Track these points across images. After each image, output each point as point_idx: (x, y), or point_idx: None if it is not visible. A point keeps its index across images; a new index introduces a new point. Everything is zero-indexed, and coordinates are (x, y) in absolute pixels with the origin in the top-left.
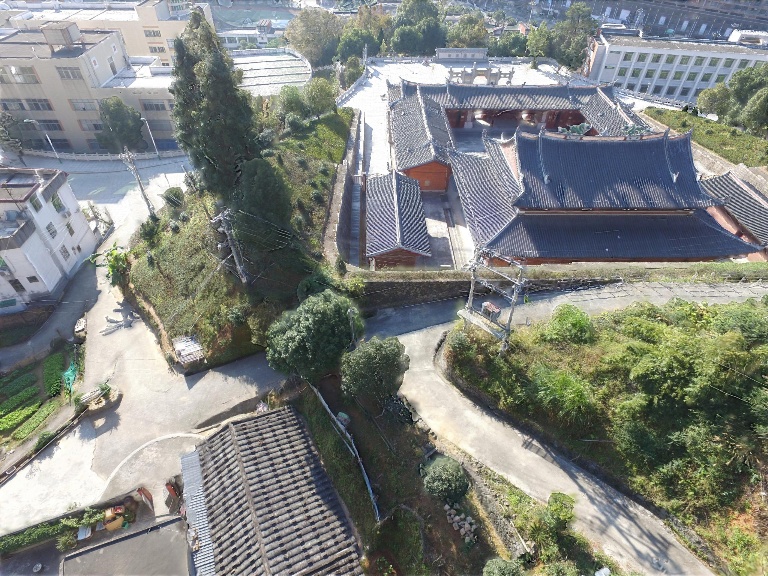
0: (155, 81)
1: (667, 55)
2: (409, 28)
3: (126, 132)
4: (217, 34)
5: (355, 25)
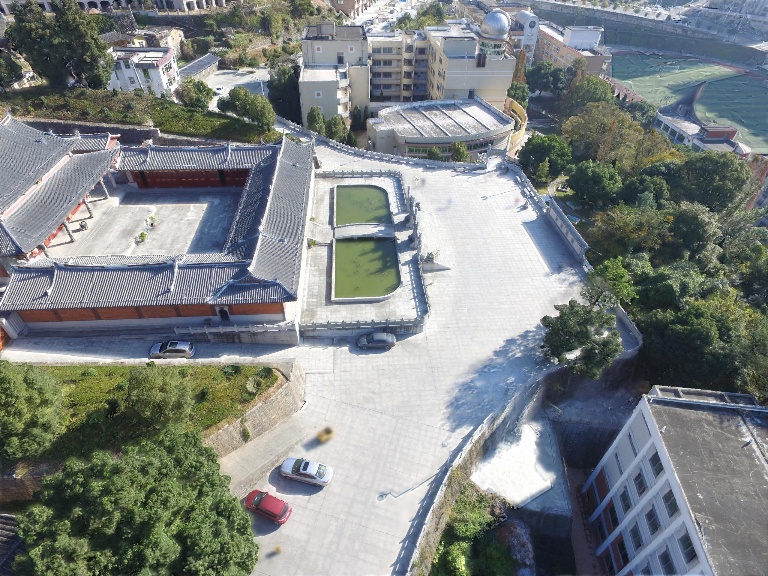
0: (328, 74)
1: (704, 573)
2: (586, 165)
3: (272, 86)
4: (660, 116)
5: (634, 148)
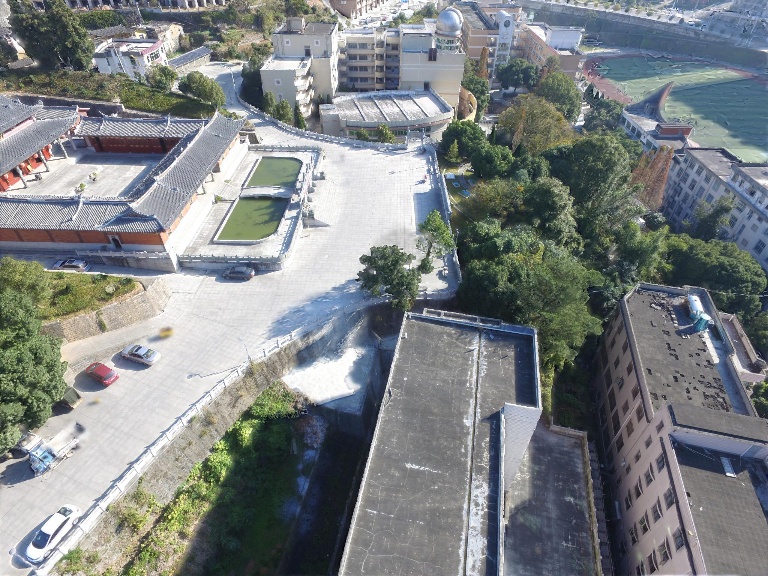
0: (292, 64)
1: None
2: (481, 146)
3: (244, 75)
4: (624, 113)
5: None
